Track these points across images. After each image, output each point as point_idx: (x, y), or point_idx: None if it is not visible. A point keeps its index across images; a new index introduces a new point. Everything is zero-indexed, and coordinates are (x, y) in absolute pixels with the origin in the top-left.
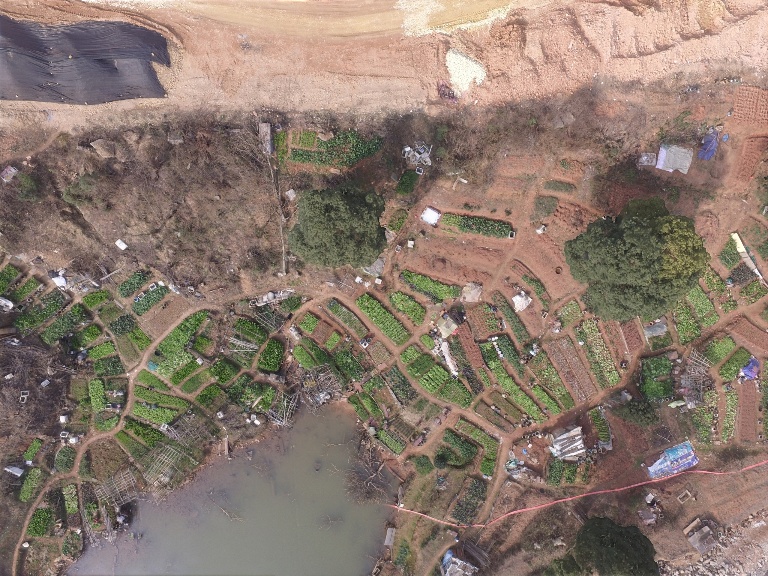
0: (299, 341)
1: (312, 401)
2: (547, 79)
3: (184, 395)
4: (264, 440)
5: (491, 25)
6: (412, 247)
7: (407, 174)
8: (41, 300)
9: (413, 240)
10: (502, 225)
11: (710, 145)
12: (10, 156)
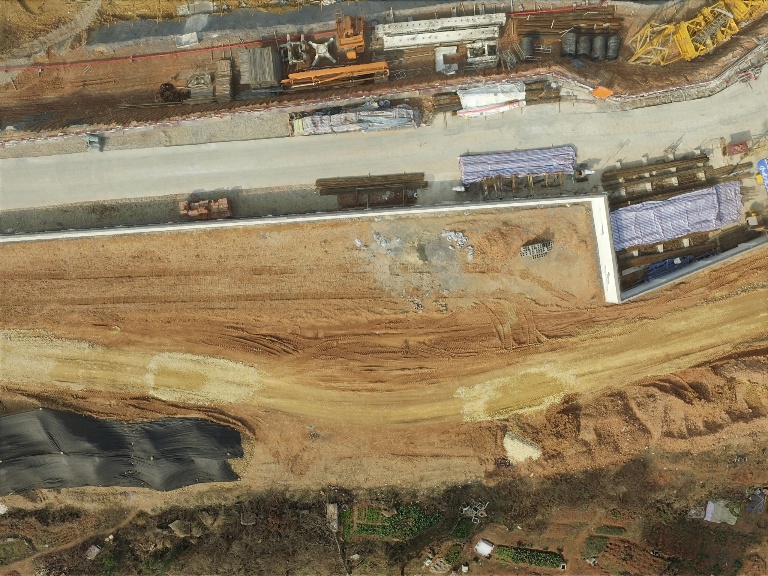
0: None
1: None
2: (601, 458)
3: None
4: None
5: (546, 410)
6: (466, 571)
7: (464, 522)
8: None
9: (467, 565)
10: (554, 558)
11: (758, 505)
12: (93, 533)
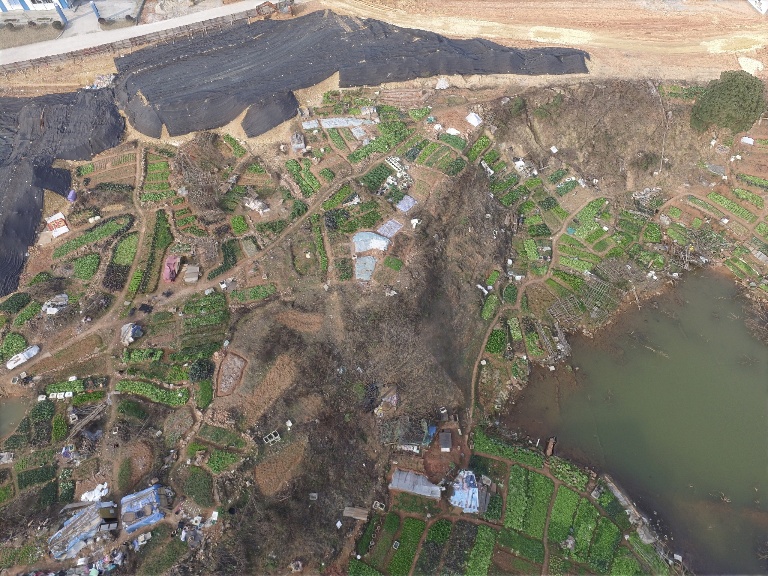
0: (669, 226)
1: (696, 261)
2: None
3: (596, 254)
4: (663, 294)
5: (756, 50)
6: (740, 159)
7: None
8: (503, 177)
9: None
10: None
11: None
12: (503, 95)
